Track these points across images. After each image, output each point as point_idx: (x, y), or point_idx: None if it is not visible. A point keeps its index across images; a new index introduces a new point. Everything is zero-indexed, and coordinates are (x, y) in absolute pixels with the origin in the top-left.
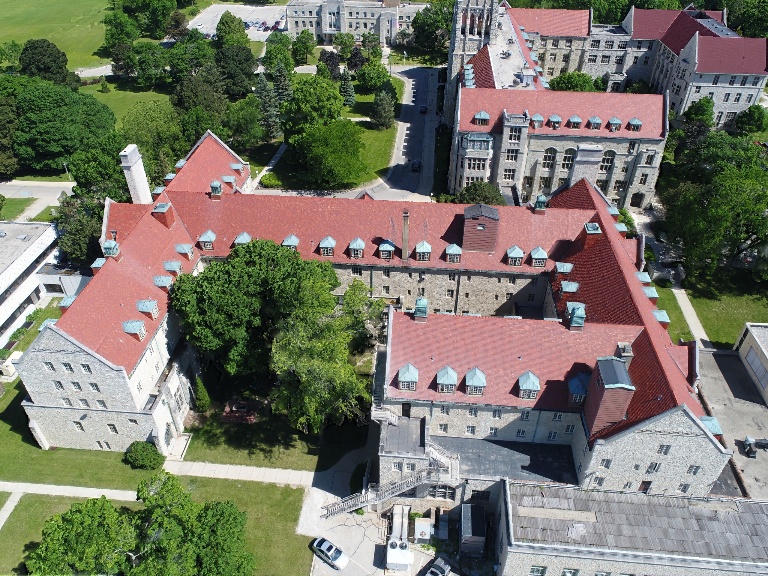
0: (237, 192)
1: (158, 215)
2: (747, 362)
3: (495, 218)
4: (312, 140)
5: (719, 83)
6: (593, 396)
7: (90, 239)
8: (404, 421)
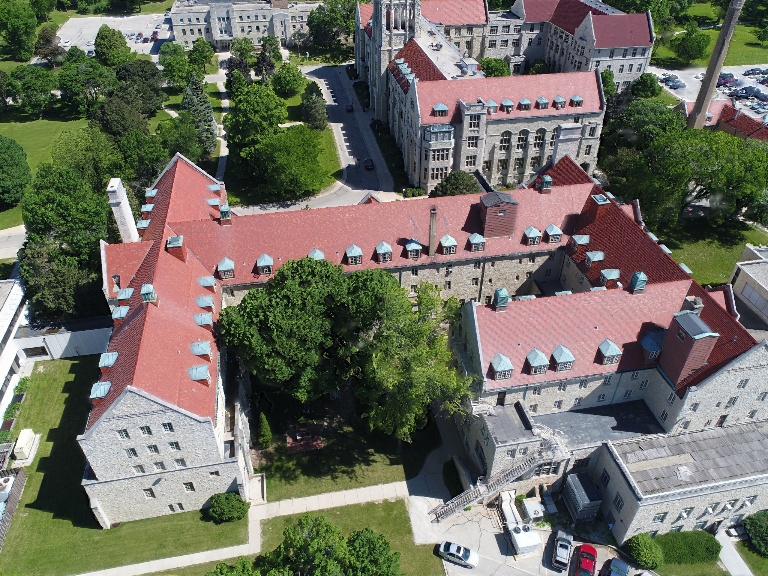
0: (232, 214)
1: (173, 250)
2: (744, 297)
3: (514, 203)
4: (271, 151)
5: (614, 56)
6: (674, 349)
7: (74, 289)
8: (500, 410)
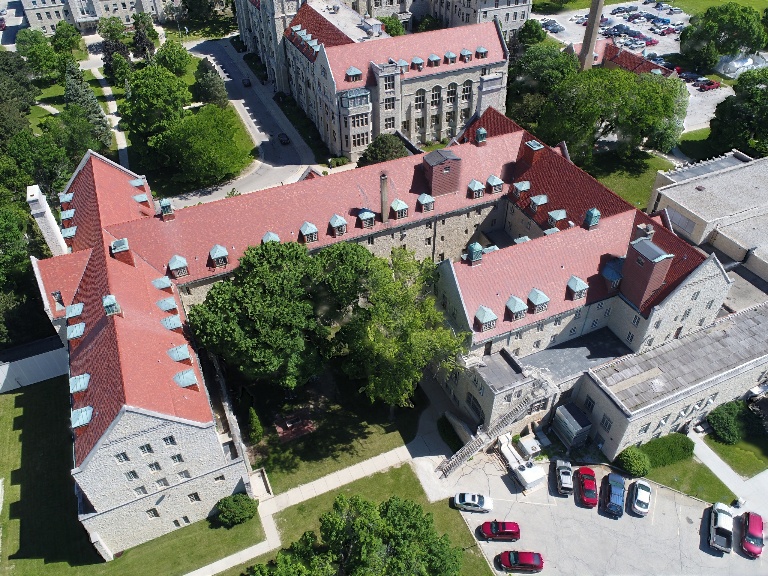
0: None
1: (120, 255)
2: None
3: (457, 158)
4: (184, 136)
5: (499, 6)
6: (635, 275)
7: (4, 316)
8: (488, 359)
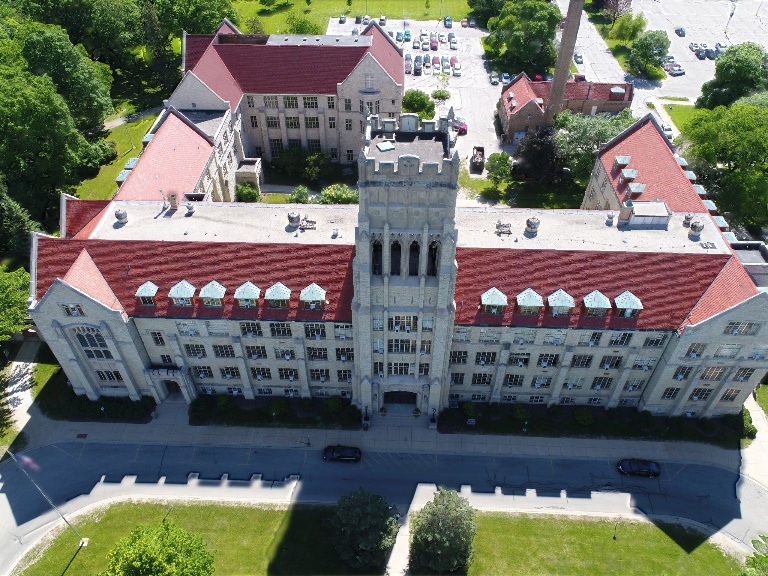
0: None
1: None
2: None
3: None
4: None
5: None
6: None
7: None
8: None
